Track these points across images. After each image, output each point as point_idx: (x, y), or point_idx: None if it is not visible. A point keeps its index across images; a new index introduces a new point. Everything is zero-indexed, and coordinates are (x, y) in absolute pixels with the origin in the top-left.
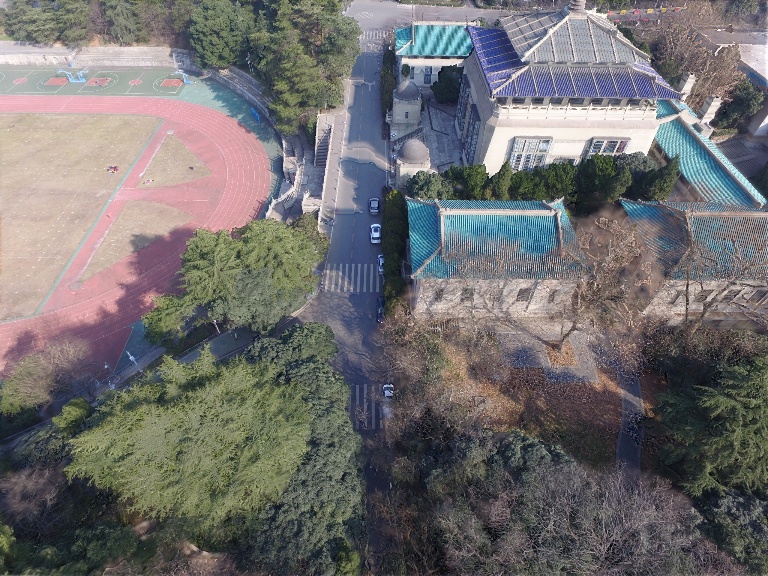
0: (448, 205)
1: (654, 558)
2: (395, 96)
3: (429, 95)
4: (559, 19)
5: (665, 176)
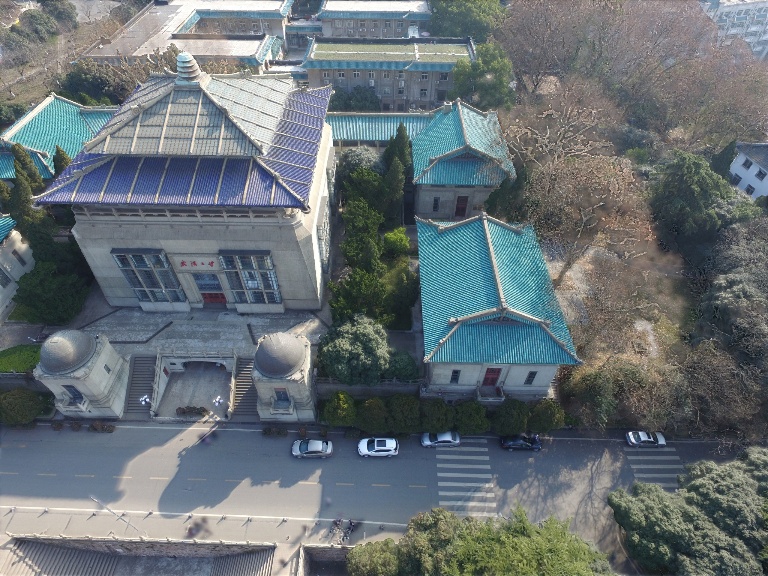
0: (455, 311)
1: (765, 255)
2: (68, 373)
3: (22, 337)
4: (194, 96)
5: (407, 143)
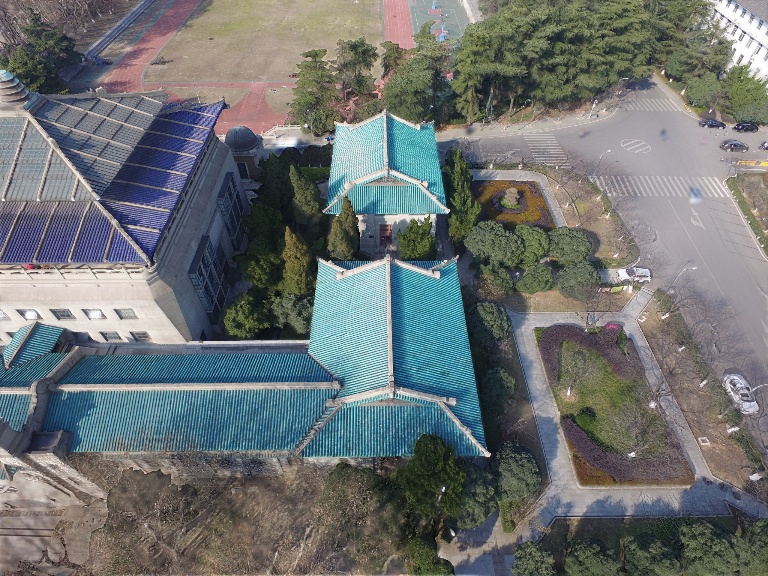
0: None
1: None
2: None
3: None
4: None
5: None
